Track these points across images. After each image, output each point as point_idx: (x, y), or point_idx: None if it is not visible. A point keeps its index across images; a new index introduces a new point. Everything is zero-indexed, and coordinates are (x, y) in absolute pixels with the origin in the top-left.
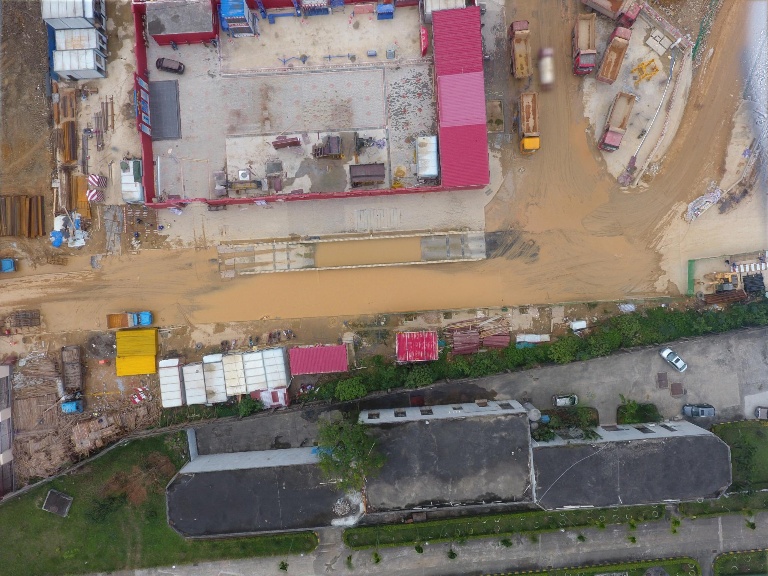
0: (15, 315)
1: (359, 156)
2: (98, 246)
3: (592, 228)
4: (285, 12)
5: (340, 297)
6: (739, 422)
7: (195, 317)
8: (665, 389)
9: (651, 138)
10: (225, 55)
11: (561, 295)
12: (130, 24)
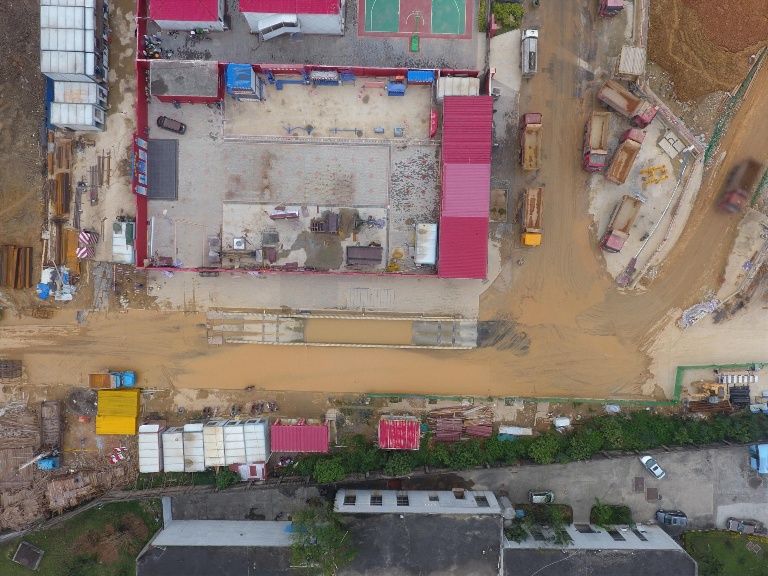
0: None
1: (357, 234)
2: (85, 302)
3: (585, 326)
4: (294, 79)
5: (327, 373)
6: (710, 531)
7: (179, 381)
8: (641, 493)
9: (654, 241)
10: (229, 119)
11: (548, 390)
12: (133, 77)
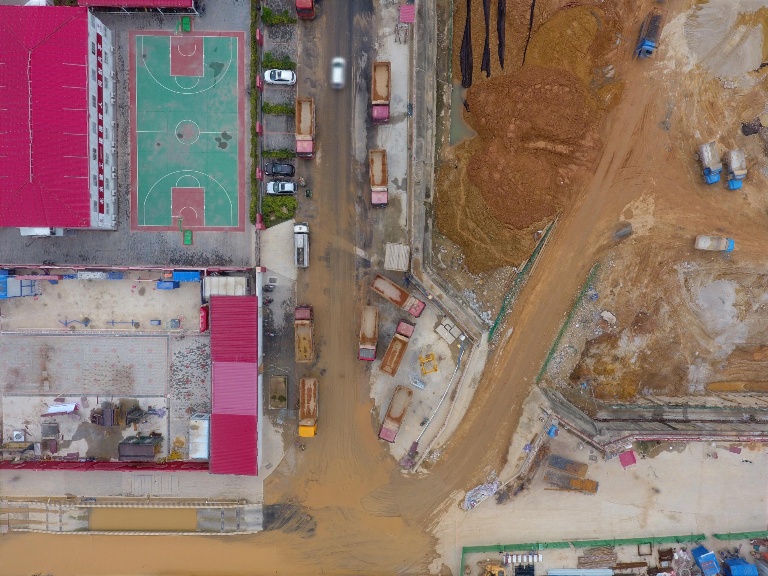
0: None
1: (138, 423)
2: None
3: (370, 508)
4: (69, 273)
5: (114, 559)
6: None
7: None
8: None
9: (434, 425)
10: None
11: (335, 571)
12: None
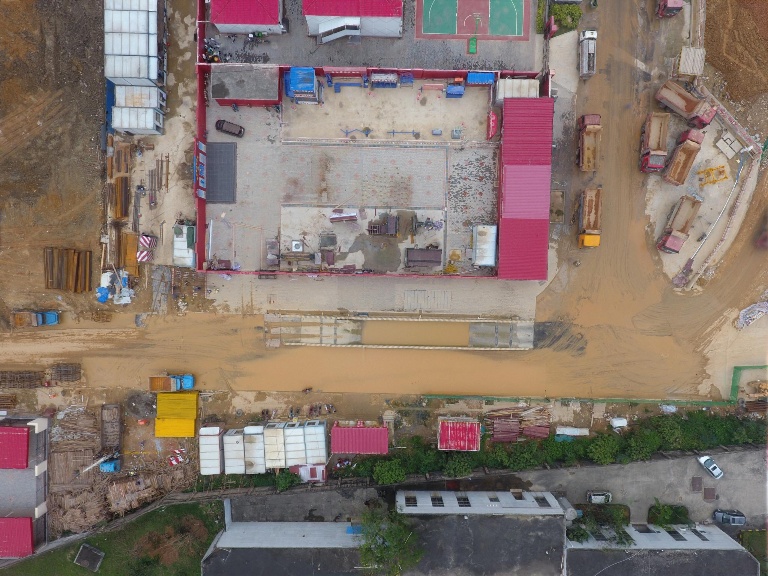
0: (56, 368)
1: (415, 236)
2: (144, 305)
3: (642, 326)
4: (352, 82)
5: (384, 375)
6: (767, 531)
7: (237, 383)
8: (698, 493)
9: (710, 242)
10: (287, 122)
11: (604, 390)
12: (191, 81)
